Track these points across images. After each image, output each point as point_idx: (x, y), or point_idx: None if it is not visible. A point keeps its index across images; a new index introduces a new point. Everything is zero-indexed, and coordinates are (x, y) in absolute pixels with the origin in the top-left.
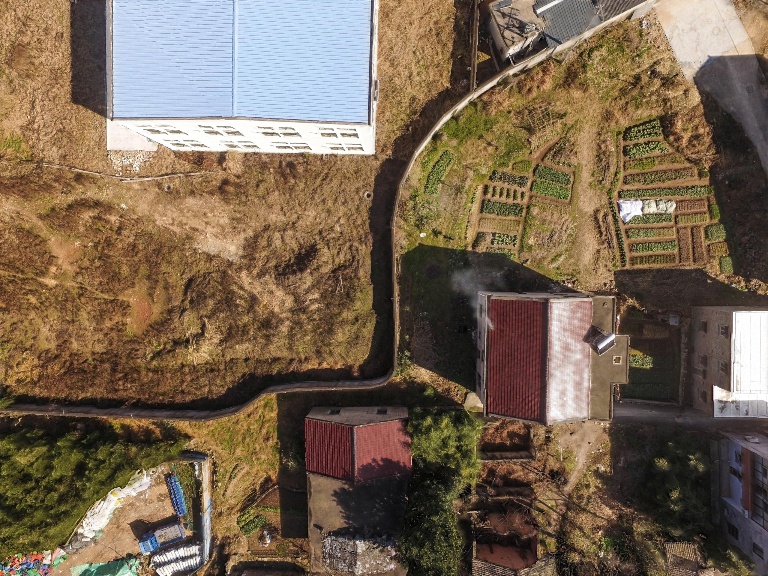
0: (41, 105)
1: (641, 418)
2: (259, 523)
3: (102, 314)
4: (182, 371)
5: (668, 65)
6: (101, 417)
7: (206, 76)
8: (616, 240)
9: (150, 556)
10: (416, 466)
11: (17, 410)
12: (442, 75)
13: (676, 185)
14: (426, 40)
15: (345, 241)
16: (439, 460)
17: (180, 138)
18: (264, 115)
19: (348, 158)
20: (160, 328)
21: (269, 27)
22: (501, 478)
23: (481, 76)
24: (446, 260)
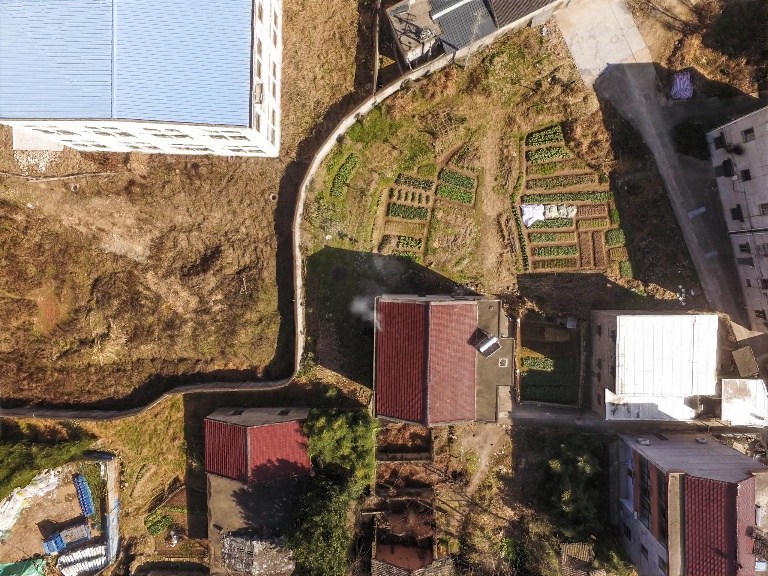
0: None
1: (542, 420)
2: (166, 523)
3: (8, 313)
4: (88, 371)
5: (567, 72)
6: (6, 417)
7: (86, 77)
8: (519, 244)
9: (57, 556)
10: (318, 467)
11: None
12: (346, 79)
13: (577, 190)
14: (330, 44)
15: (250, 243)
16: (339, 461)
17: (76, 139)
18: (144, 117)
19: (253, 160)
20: (66, 328)
21: (149, 30)
22: (403, 479)
23: (386, 80)
24: (352, 262)
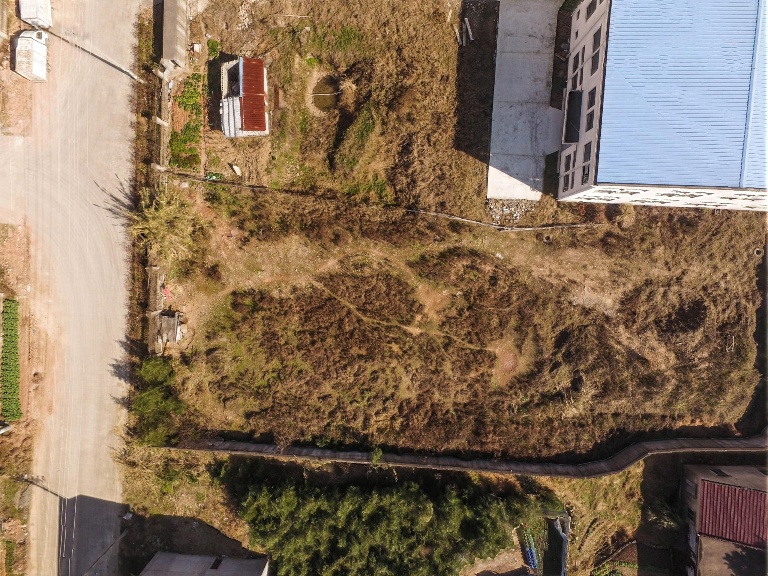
0: (419, 150)
1: None
2: None
3: (470, 365)
4: (552, 425)
5: None
6: None
7: (713, 144)
8: None
9: None
10: None
11: (391, 462)
12: None
13: None
14: None
15: (732, 298)
16: None
17: None
18: None
19: (741, 214)
20: (531, 381)
21: None
22: None
23: None
24: None
